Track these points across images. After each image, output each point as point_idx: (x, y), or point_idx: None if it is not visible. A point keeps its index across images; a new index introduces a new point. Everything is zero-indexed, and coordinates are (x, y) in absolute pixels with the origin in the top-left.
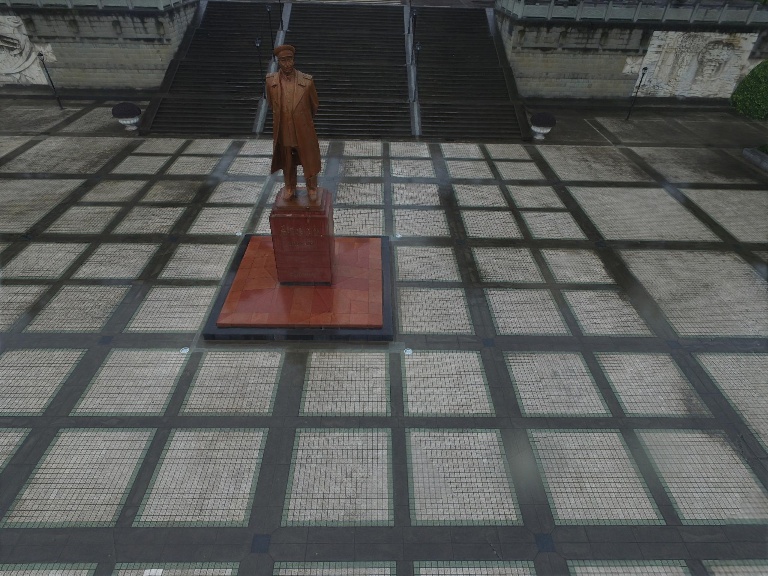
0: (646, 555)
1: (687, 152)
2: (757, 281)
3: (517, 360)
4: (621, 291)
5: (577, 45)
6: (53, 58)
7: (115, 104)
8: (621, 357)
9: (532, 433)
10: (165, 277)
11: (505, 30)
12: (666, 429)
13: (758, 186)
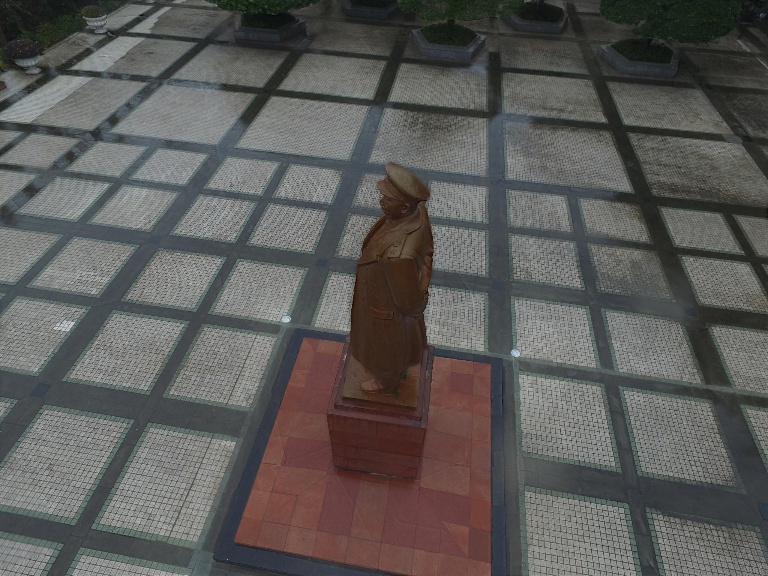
0: None
1: None
2: None
3: None
4: None
5: None
6: None
7: None
8: None
9: None
10: None
11: None
12: None
13: None
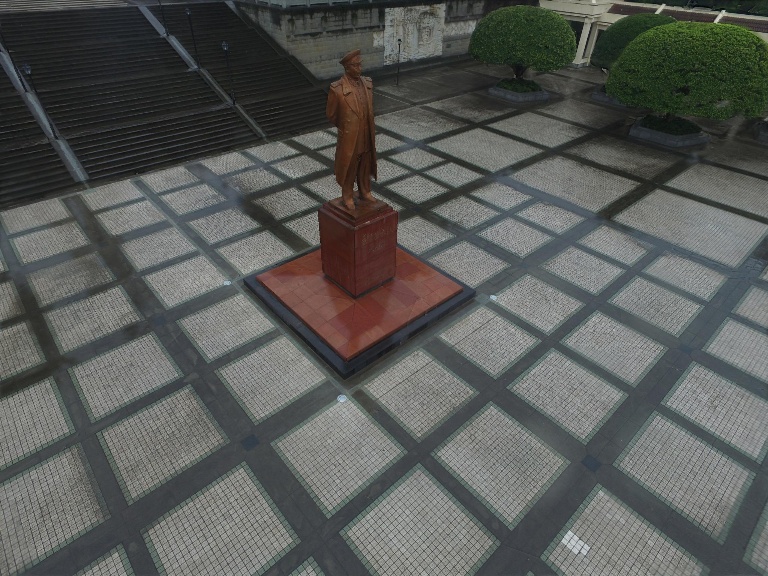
0: (716, 325)
1: (460, 99)
2: (585, 167)
3: (552, 267)
4: (541, 200)
5: (336, 27)
6: None
7: None
8: (589, 238)
9: (611, 302)
10: (215, 357)
11: (266, 21)
12: (650, 263)
13: (519, 111)
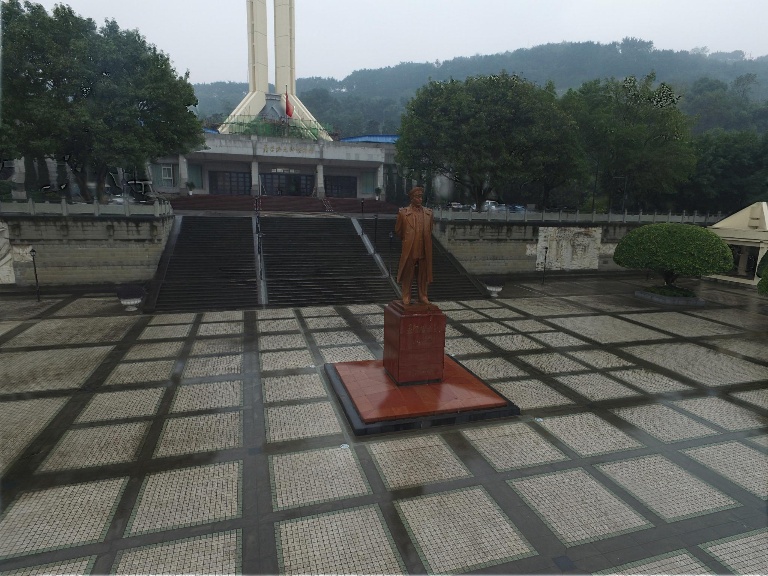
0: None
1: (600, 297)
2: (719, 354)
3: (623, 413)
4: (645, 368)
5: (492, 237)
6: (30, 259)
7: (98, 295)
8: (688, 402)
9: (684, 451)
10: (271, 401)
11: (436, 230)
12: (763, 435)
13: (662, 310)
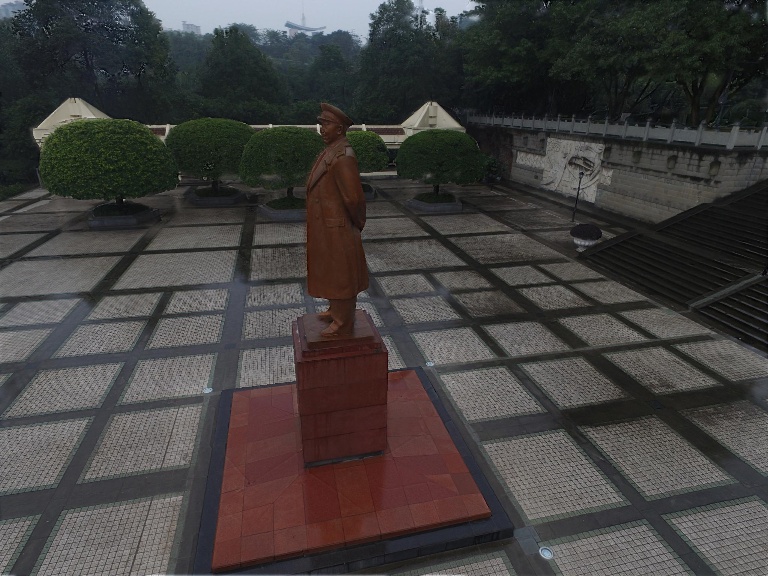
0: None
1: None
2: None
3: None
4: None
5: None
6: (609, 182)
7: None
8: None
9: None
10: None
11: None
12: None
13: None
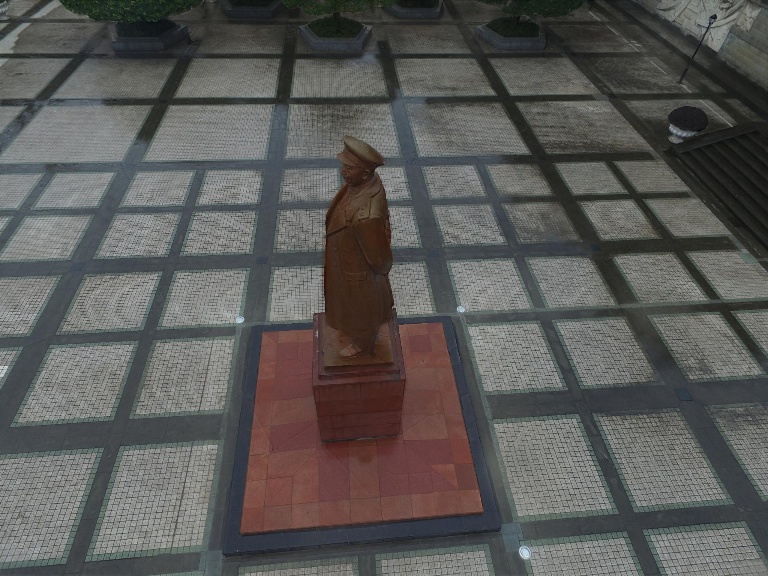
0: None
1: None
2: None
3: None
4: None
5: None
6: (749, 26)
7: (730, 106)
8: None
9: None
10: None
11: None
12: None
13: None
